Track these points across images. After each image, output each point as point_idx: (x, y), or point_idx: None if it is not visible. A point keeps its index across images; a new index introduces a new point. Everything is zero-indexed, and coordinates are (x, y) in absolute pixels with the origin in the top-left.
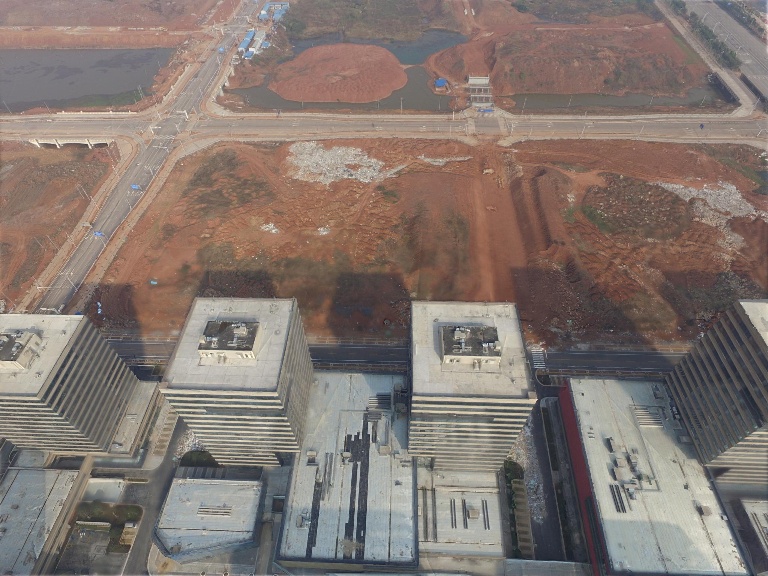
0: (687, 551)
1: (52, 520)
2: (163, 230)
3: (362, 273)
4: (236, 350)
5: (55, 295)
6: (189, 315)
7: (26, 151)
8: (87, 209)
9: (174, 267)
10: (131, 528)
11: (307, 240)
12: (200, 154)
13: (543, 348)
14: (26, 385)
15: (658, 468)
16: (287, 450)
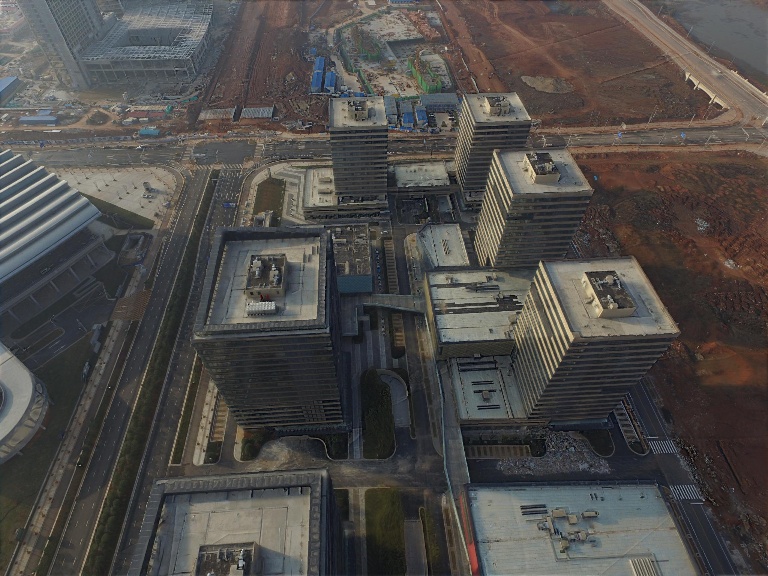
0: (503, 571)
1: (424, 185)
2: (649, 165)
3: (694, 301)
4: (533, 168)
5: (557, 139)
6: (550, 148)
7: (675, 77)
8: (641, 124)
9: (617, 182)
10: (428, 221)
11: (707, 253)
12: (764, 160)
13: (705, 500)
14: (480, 118)
15: (583, 567)
16: (491, 259)
